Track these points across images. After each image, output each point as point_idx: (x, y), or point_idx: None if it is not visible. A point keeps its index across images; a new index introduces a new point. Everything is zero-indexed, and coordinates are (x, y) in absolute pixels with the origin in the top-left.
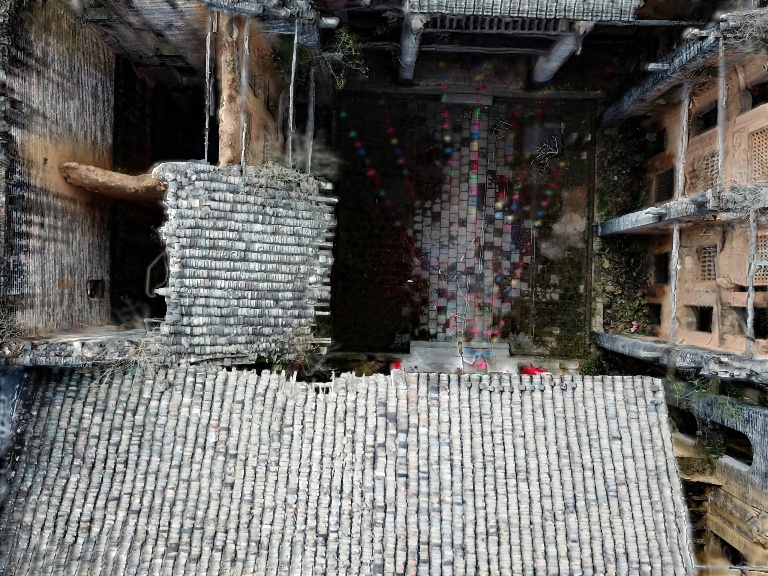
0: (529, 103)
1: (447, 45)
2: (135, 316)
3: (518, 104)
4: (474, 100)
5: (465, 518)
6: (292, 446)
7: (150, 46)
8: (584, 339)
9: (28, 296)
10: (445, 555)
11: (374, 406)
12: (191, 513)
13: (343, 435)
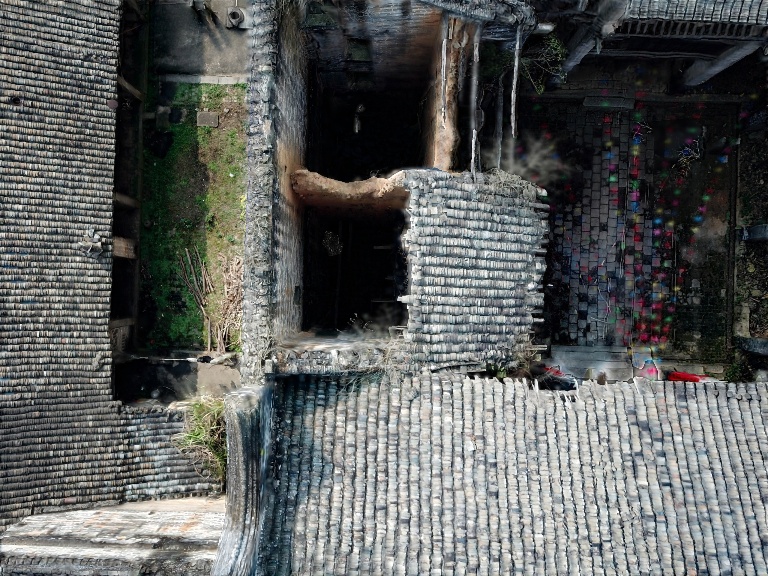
0: (671, 107)
1: (613, 49)
2: (318, 322)
3: (659, 108)
4: (616, 104)
5: (736, 527)
6: (550, 455)
7: (344, 52)
8: (725, 343)
9: (277, 304)
10: (723, 565)
11: (624, 414)
12: (461, 522)
13: (598, 444)
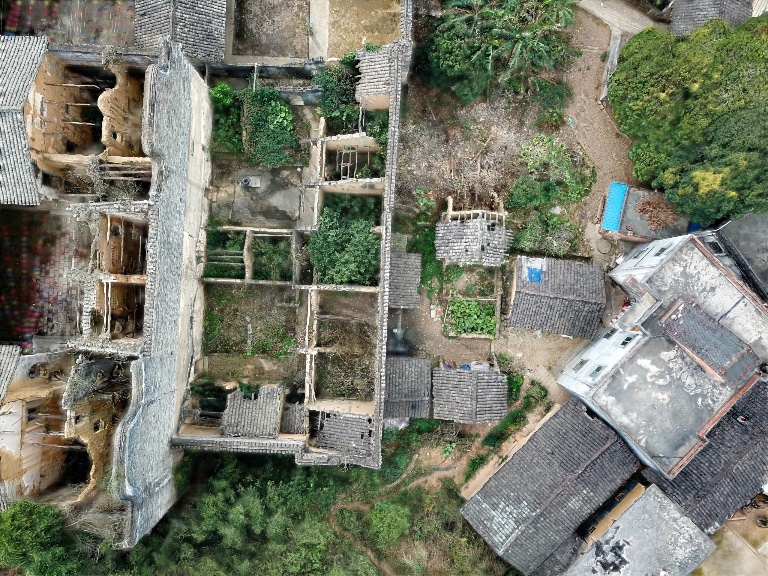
0: None
1: None
2: None
3: None
4: (66, 213)
5: None
6: None
7: None
8: None
9: None
10: None
11: None
12: None
13: None
